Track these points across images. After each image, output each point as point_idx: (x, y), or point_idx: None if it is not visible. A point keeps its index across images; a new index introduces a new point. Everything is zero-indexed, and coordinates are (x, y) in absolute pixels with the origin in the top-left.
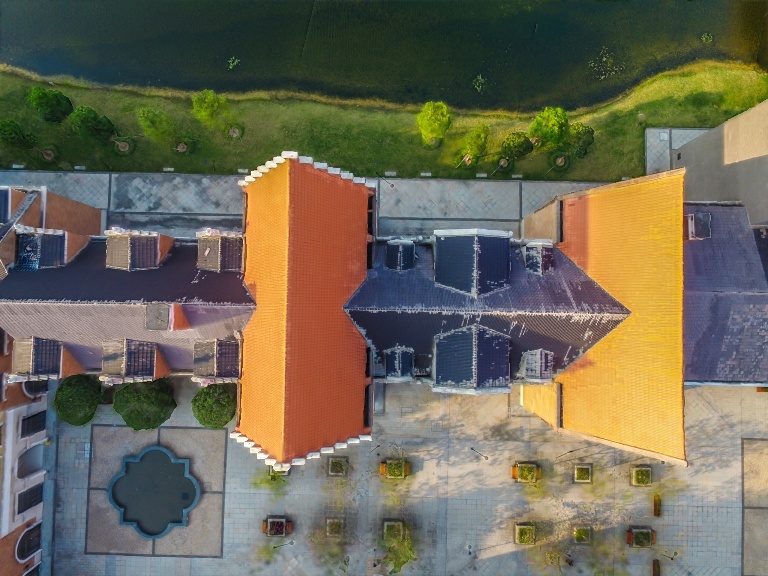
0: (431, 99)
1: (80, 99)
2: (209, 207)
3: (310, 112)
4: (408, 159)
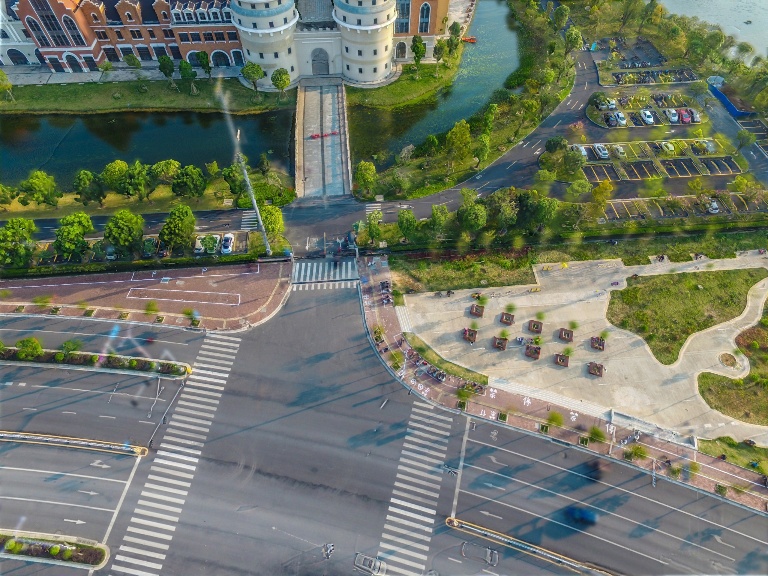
0: (6, 116)
1: (197, 103)
2: (136, 72)
3: (75, 106)
4: (28, 90)
